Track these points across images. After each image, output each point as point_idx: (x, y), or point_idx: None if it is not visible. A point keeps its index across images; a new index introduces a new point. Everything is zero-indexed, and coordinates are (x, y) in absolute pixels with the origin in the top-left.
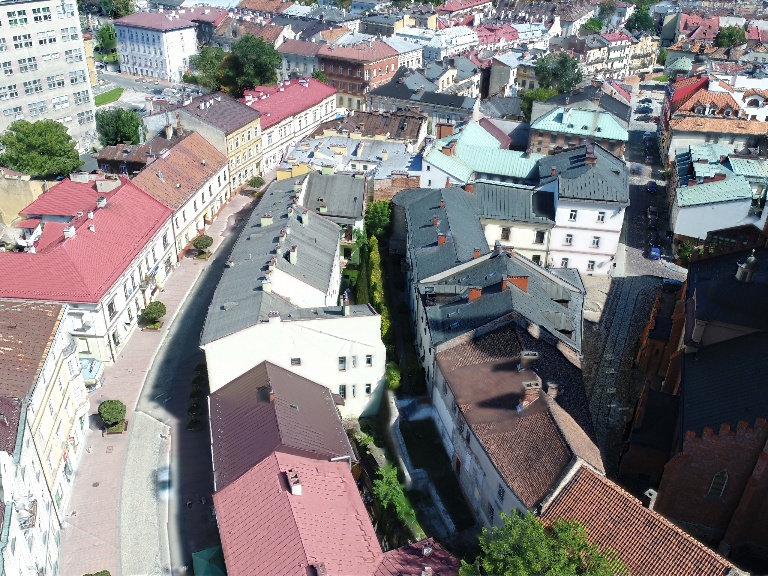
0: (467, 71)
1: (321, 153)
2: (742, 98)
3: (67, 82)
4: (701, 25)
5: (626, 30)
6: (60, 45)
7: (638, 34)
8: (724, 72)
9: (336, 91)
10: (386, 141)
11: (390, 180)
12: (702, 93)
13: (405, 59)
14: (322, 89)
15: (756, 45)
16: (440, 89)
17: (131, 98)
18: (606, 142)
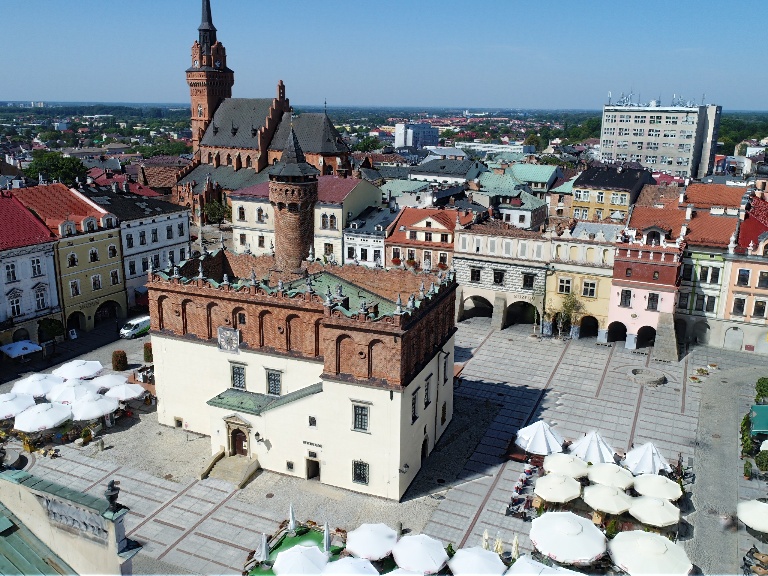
0: None
1: None
2: None
3: (674, 163)
4: None
5: None
6: (677, 140)
7: None
8: None
9: None
10: None
11: None
12: None
13: None
14: None
15: None
16: None
17: None
18: None
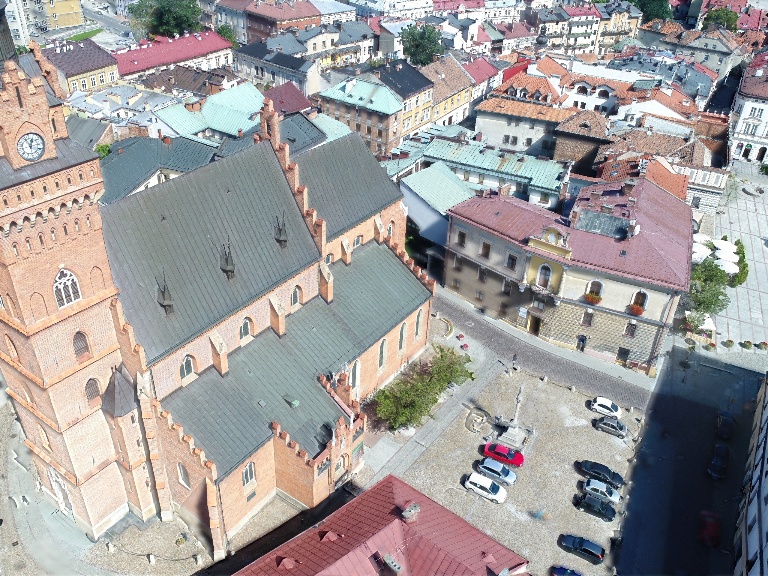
0: (356, 36)
1: (92, 99)
2: (562, 84)
3: None
4: (724, 4)
5: (630, 4)
6: None
7: (611, 10)
8: (568, 56)
9: (231, 46)
10: (162, 94)
11: (127, 128)
12: (521, 75)
13: (331, 20)
14: (216, 43)
15: (713, 30)
16: (310, 51)
17: (100, 39)
18: (376, 114)
